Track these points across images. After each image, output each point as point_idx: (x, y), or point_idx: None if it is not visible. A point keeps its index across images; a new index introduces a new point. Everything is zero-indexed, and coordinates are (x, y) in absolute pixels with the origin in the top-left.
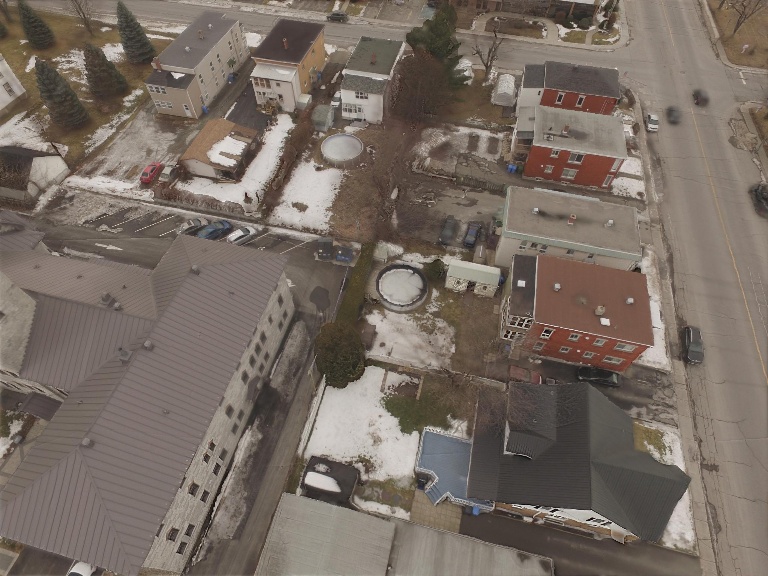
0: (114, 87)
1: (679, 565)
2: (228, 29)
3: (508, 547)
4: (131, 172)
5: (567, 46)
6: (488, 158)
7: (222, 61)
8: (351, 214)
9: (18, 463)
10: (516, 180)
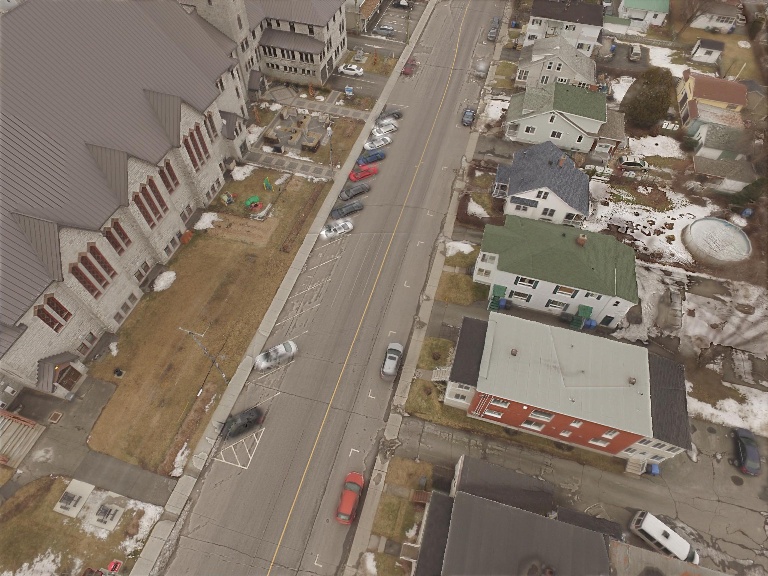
0: None
1: None
2: None
3: None
4: None
5: None
6: None
7: None
8: None
9: (287, 100)
10: None
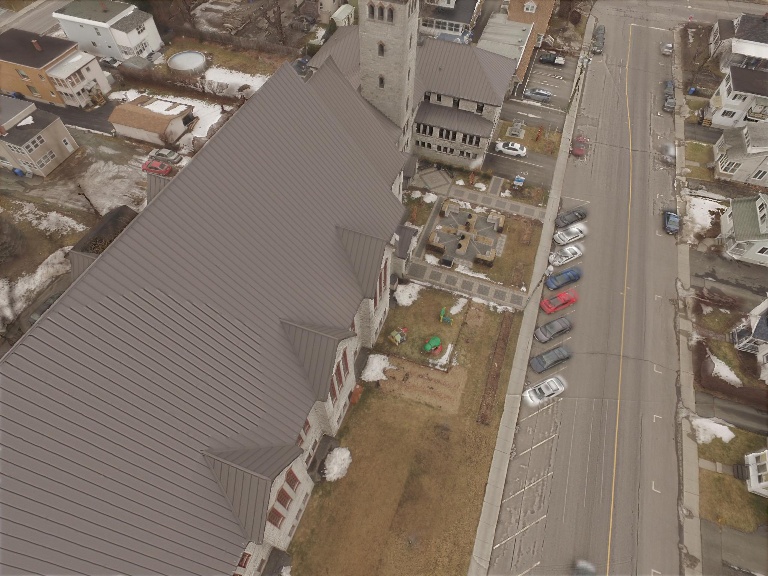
0: None
1: (489, 2)
2: None
3: None
4: (145, 185)
5: None
6: (234, 7)
7: None
8: (262, 66)
9: (441, 188)
10: (261, 1)
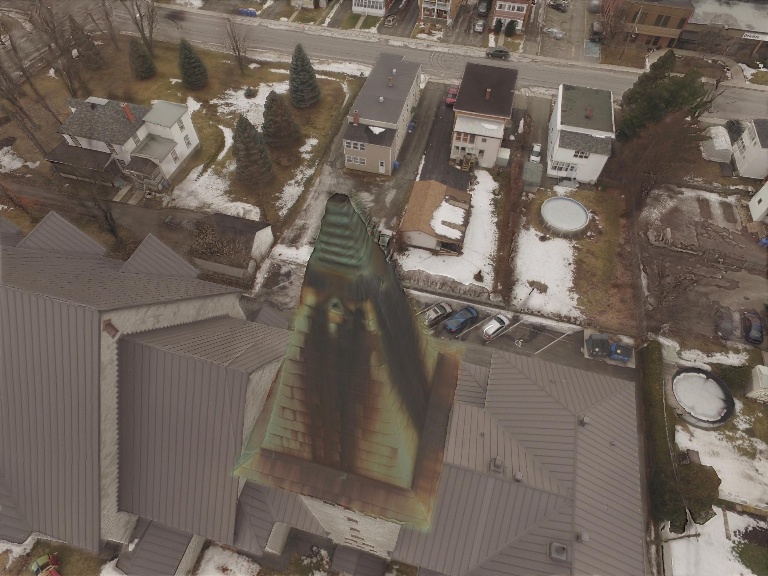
0: (291, 137)
1: None
2: (415, 75)
3: None
4: None
5: (758, 89)
6: (729, 228)
7: (408, 110)
8: (599, 297)
9: None
10: None
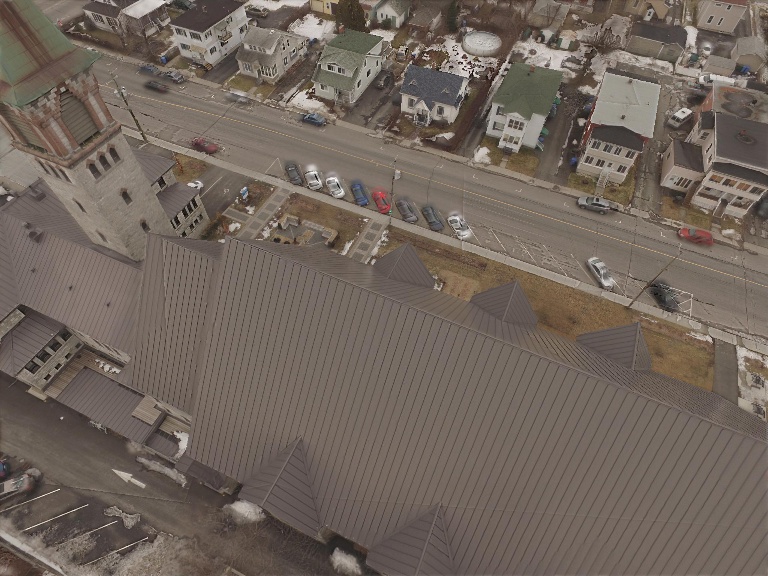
0: None
1: None
2: None
3: None
4: None
5: None
6: None
7: None
8: None
9: None
10: None
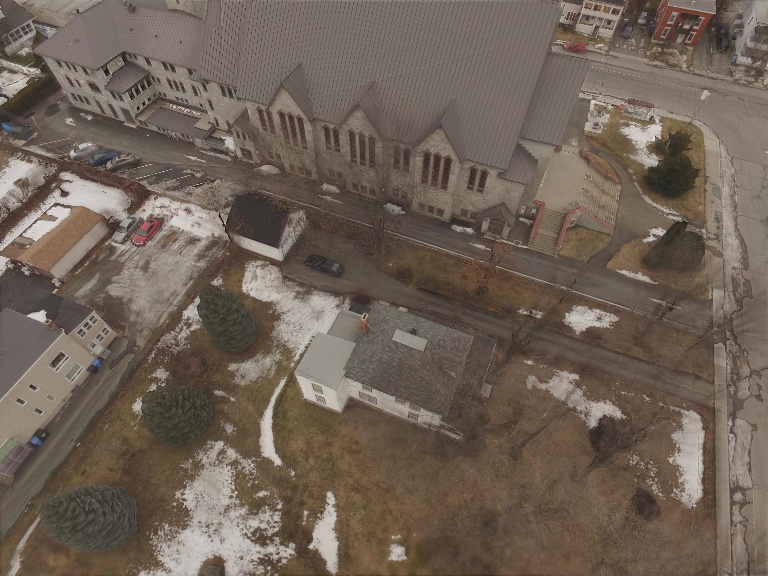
0: None
1: None
2: None
3: (34, 8)
4: (170, 239)
5: None
6: None
7: None
8: None
9: None
10: None
